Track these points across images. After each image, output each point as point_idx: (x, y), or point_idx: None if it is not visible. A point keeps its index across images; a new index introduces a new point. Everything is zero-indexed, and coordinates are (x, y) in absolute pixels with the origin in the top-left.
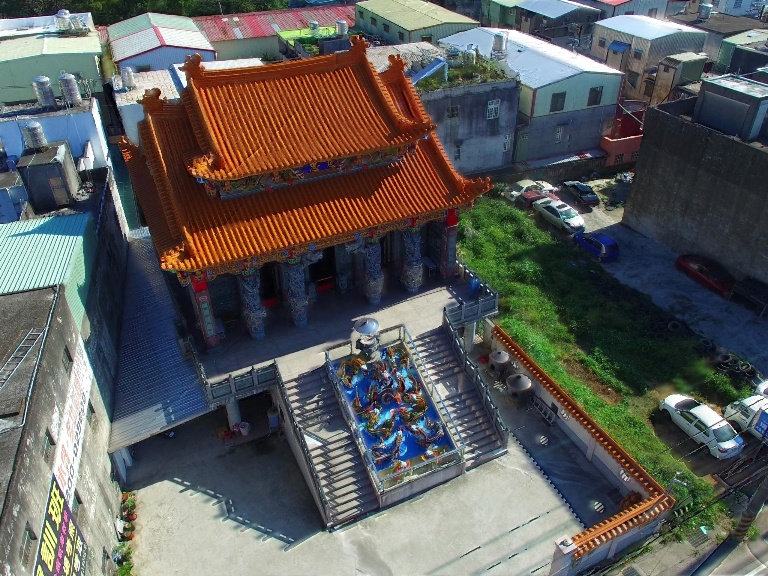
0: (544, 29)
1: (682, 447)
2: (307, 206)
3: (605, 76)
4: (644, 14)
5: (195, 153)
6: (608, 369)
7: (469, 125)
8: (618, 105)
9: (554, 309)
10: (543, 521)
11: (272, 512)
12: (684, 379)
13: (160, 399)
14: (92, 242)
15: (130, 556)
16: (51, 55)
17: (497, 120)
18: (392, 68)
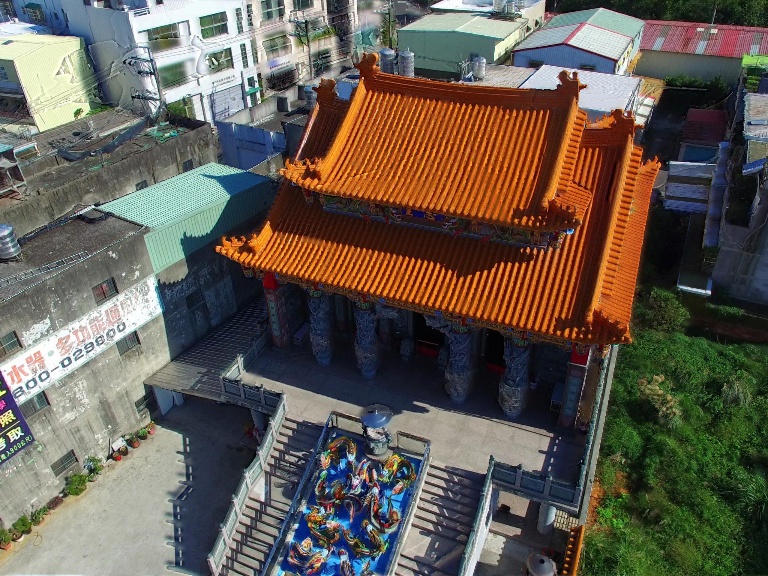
0: None
1: None
2: (392, 253)
3: None
4: None
5: None
6: None
7: None
8: None
9: (733, 570)
10: None
11: (199, 526)
12: None
13: (212, 365)
14: (255, 205)
15: (98, 472)
16: (460, 33)
17: None
18: (615, 127)
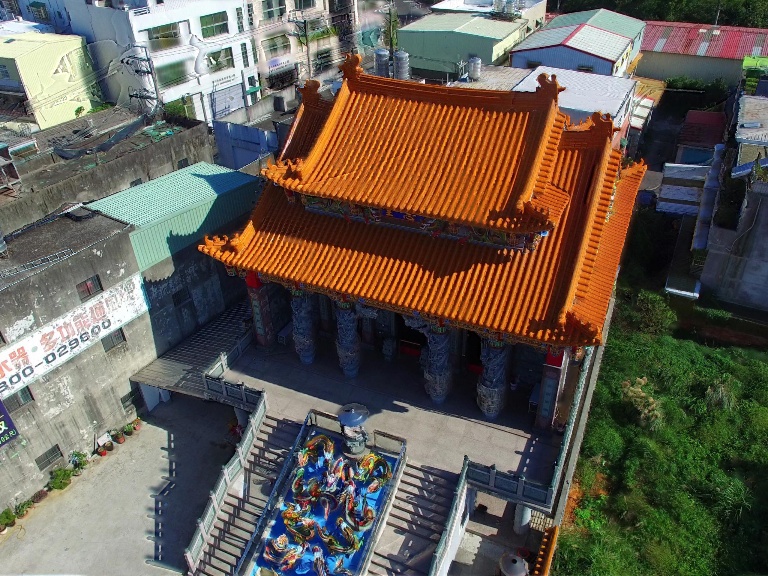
0: None
1: None
2: (371, 253)
3: None
4: None
5: None
6: None
7: None
8: None
9: (707, 573)
10: None
11: (180, 521)
12: None
13: (197, 362)
14: (243, 204)
15: (83, 467)
16: (459, 33)
17: None
18: (593, 130)
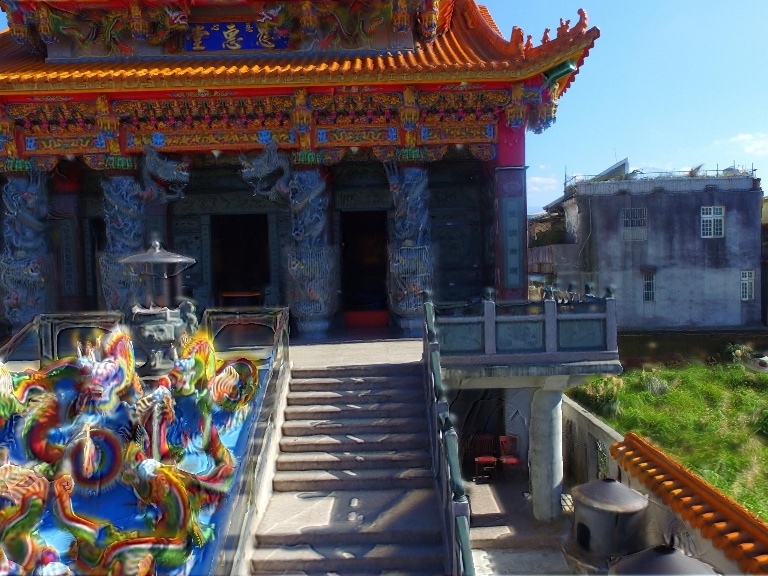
0: None
1: None
2: (174, 68)
3: None
4: None
5: None
6: None
7: (667, 243)
8: None
9: None
10: None
11: None
12: None
13: None
14: None
15: None
16: None
17: (721, 241)
18: None
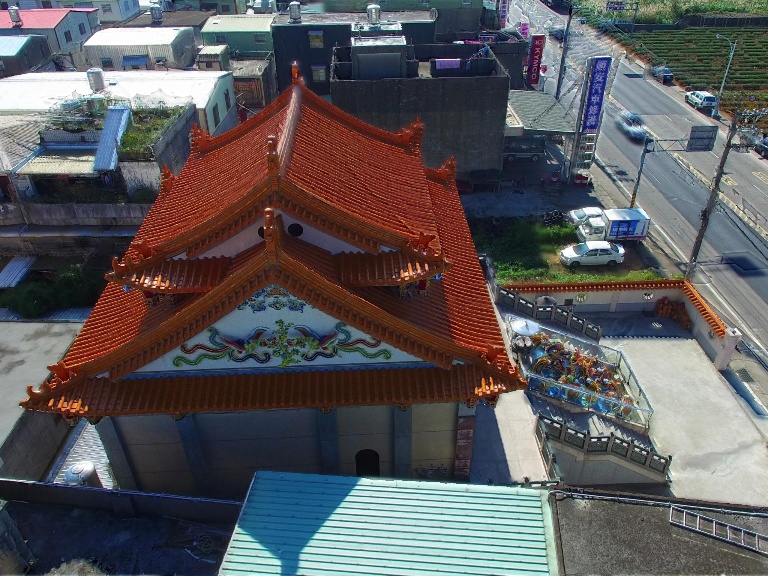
0: (38, 66)
1: (604, 273)
2: None
3: (226, 78)
4: (77, 31)
5: (354, 267)
6: (518, 269)
7: None
8: (236, 103)
9: None
10: (669, 354)
11: None
12: (544, 244)
13: None
14: None
15: None
16: None
17: None
18: None
